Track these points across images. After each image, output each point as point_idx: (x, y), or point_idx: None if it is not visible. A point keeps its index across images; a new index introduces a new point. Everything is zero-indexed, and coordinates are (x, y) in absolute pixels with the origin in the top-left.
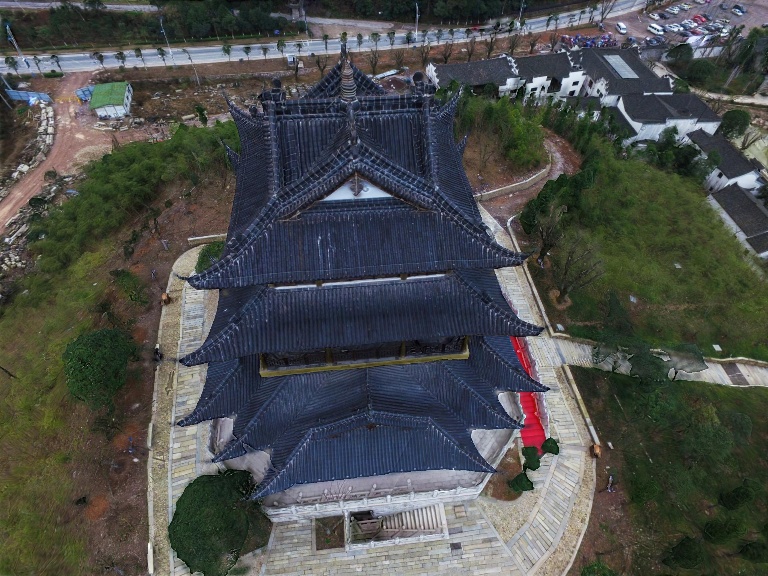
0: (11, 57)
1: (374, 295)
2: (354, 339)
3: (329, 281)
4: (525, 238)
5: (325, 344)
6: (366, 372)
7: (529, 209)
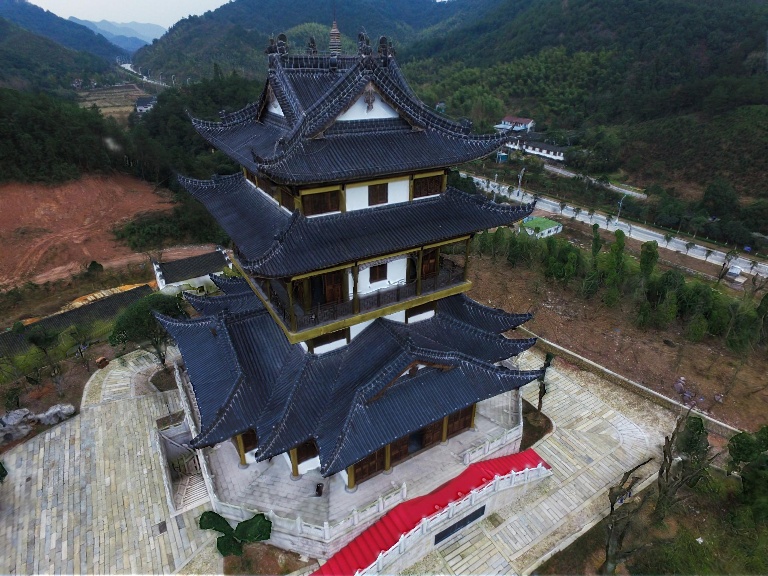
0: (513, 187)
1: (263, 208)
2: (224, 221)
3: (261, 187)
4: (685, 491)
5: (216, 215)
6: (261, 307)
7: (689, 431)
